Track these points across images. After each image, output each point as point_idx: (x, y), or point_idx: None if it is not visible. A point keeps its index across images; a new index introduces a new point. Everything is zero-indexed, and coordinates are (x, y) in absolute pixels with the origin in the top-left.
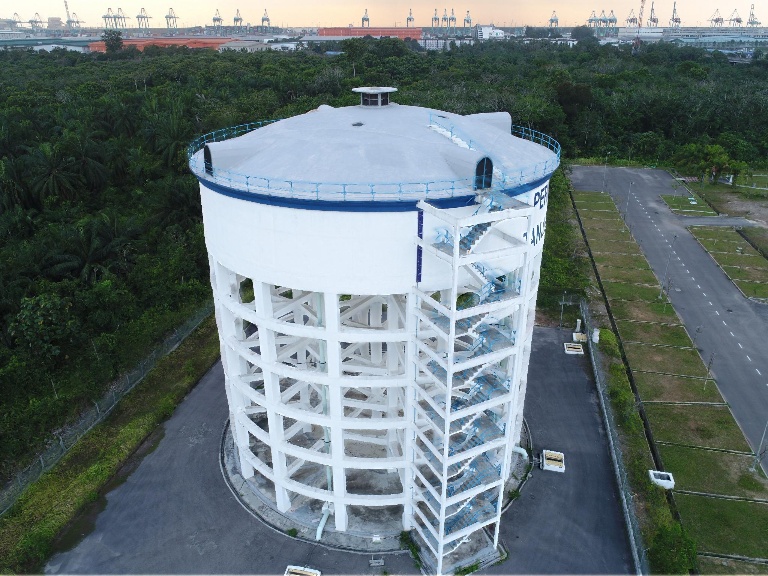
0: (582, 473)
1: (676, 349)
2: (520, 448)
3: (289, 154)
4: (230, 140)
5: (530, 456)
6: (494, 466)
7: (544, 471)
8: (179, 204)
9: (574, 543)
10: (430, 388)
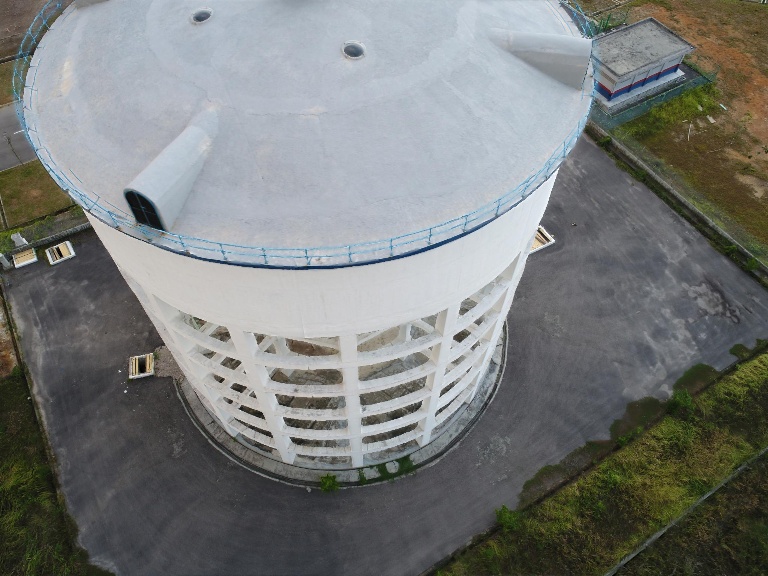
0: None
1: (3, 186)
2: None
3: (505, 4)
4: (448, 196)
5: None
6: None
7: None
8: None
9: None
10: None
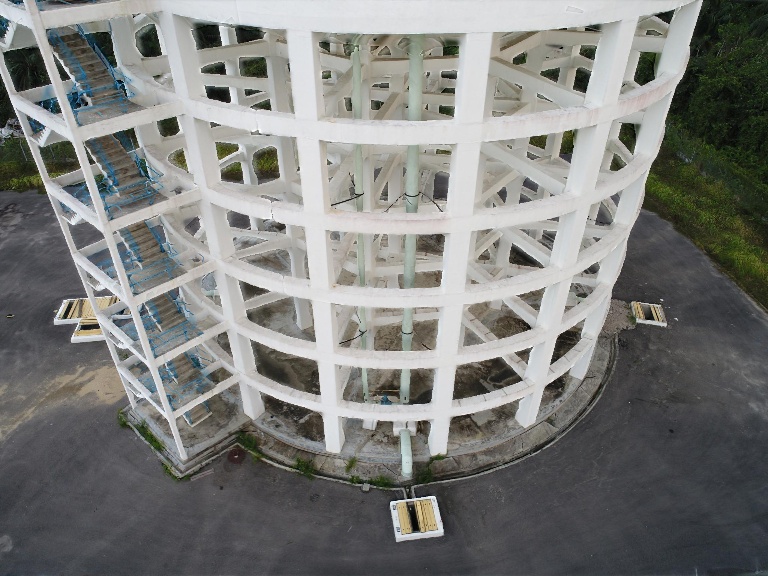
0: (408, 575)
1: None
2: (406, 453)
3: None
4: None
5: (417, 482)
6: (280, 395)
7: (386, 508)
8: (668, 14)
9: (224, 572)
10: (351, 257)
